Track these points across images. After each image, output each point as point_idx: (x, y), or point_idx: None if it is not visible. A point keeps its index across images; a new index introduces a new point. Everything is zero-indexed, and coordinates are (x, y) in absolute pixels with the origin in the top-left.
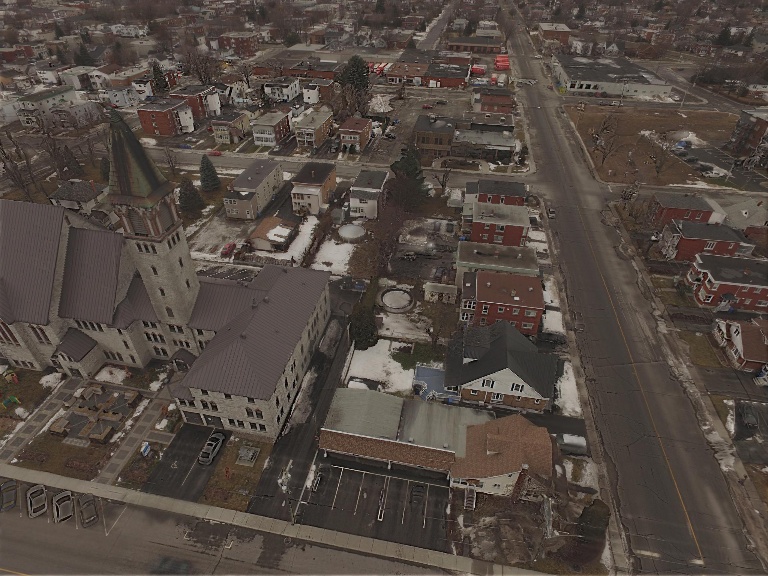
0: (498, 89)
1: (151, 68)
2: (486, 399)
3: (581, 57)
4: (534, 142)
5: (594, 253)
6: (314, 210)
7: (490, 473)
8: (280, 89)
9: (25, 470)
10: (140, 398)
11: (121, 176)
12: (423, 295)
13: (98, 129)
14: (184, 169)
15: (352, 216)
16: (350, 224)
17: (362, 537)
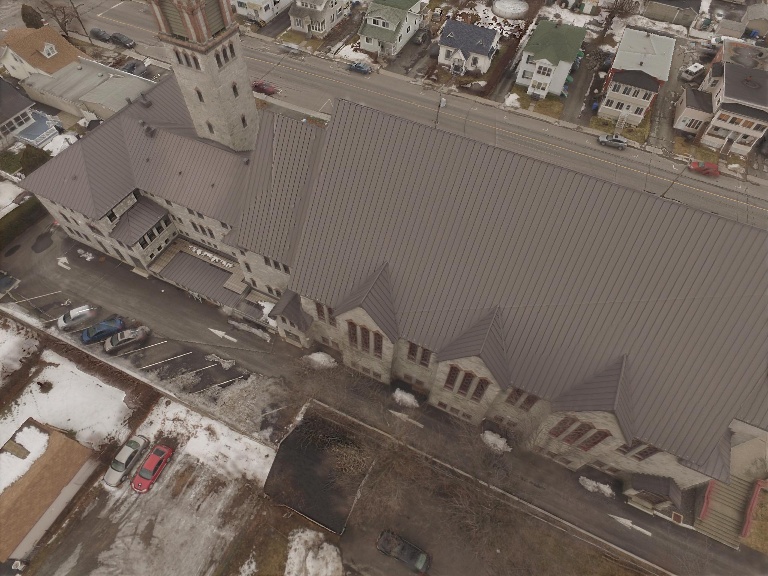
0: None
1: None
2: None
3: None
4: None
5: None
6: None
7: (68, 43)
8: None
9: None
10: None
11: None
12: None
13: None
14: None
15: None
16: None
17: None
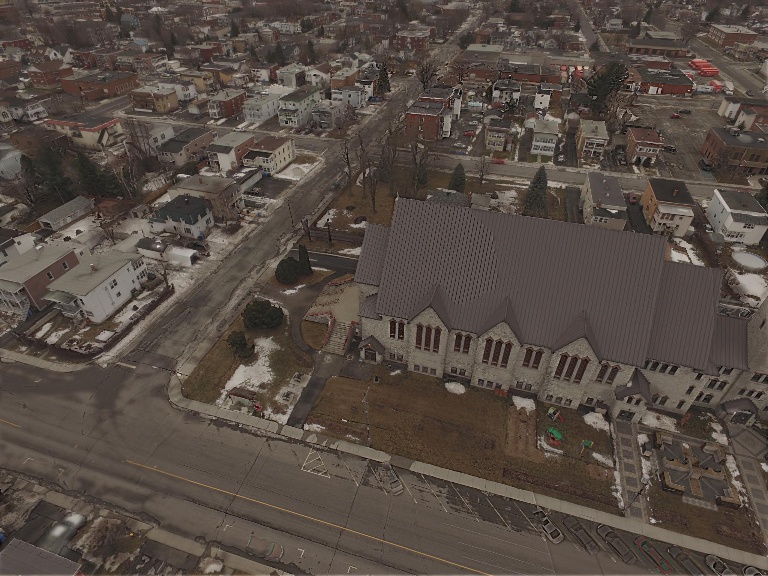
0: (757, 99)
1: (362, 68)
2: None
3: None
4: None
5: None
6: (679, 232)
7: None
8: (509, 93)
9: (677, 534)
10: None
11: None
12: None
13: (354, 131)
14: (483, 178)
15: (725, 241)
16: (739, 251)
17: None
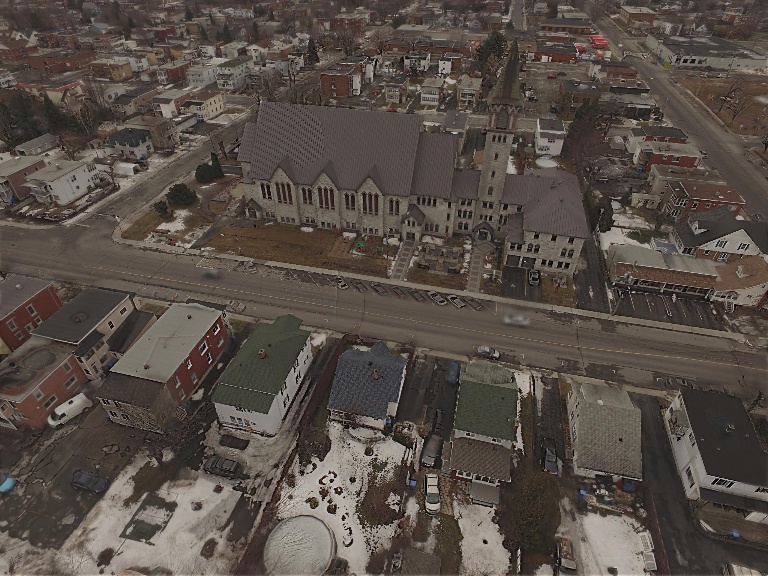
0: None
1: (296, 43)
2: (714, 258)
3: (677, 36)
4: (661, 105)
5: (751, 181)
6: None
7: (748, 286)
8: (418, 61)
9: (417, 284)
10: (463, 252)
11: (507, 85)
12: (629, 203)
13: (280, 91)
14: None
15: (538, 154)
16: (542, 158)
17: (663, 322)
